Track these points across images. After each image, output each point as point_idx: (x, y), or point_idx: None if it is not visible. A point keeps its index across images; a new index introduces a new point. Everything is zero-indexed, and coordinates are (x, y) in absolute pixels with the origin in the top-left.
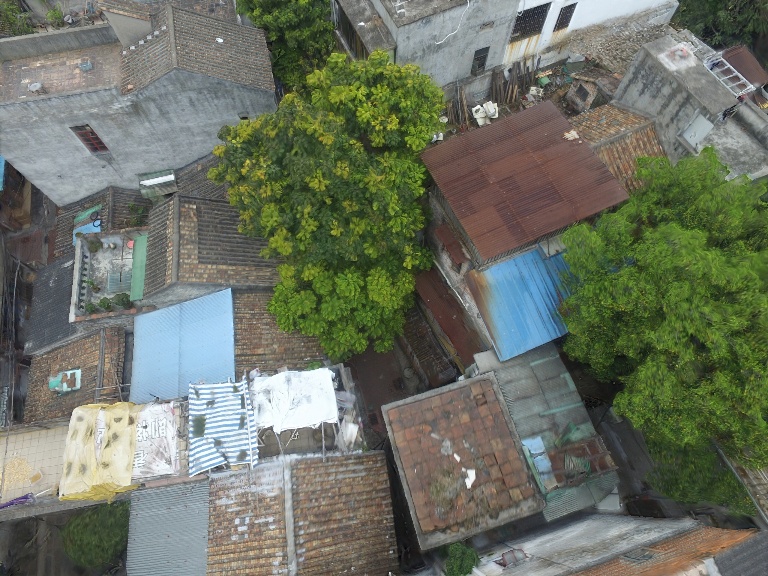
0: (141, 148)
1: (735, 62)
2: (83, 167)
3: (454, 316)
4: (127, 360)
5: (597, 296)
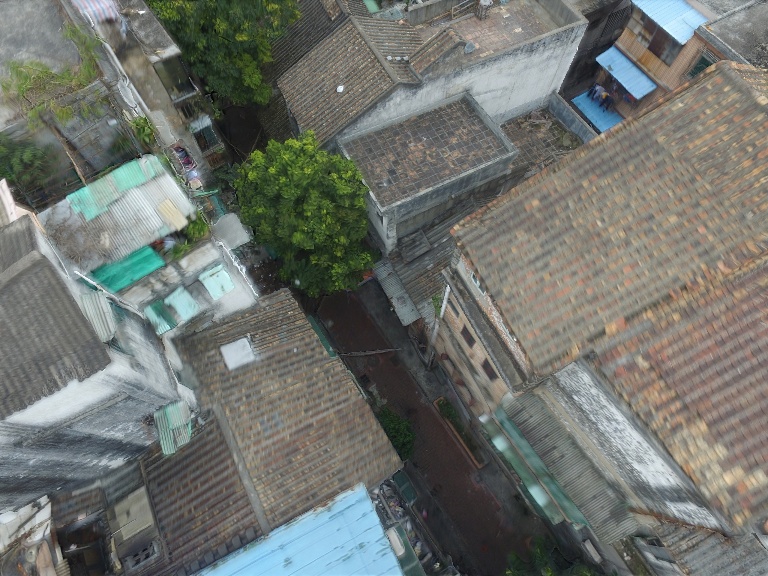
0: None
1: None
2: None
3: None
4: None
5: None
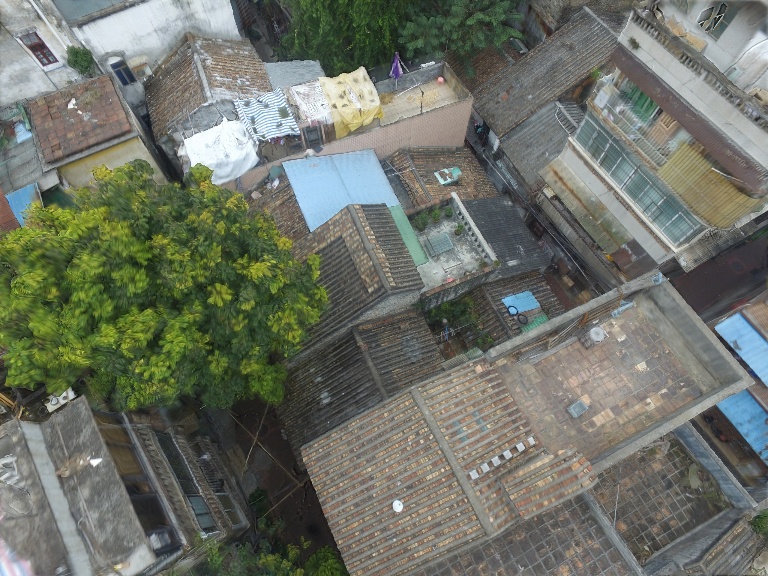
0: None
1: None
2: None
3: None
4: None
5: None
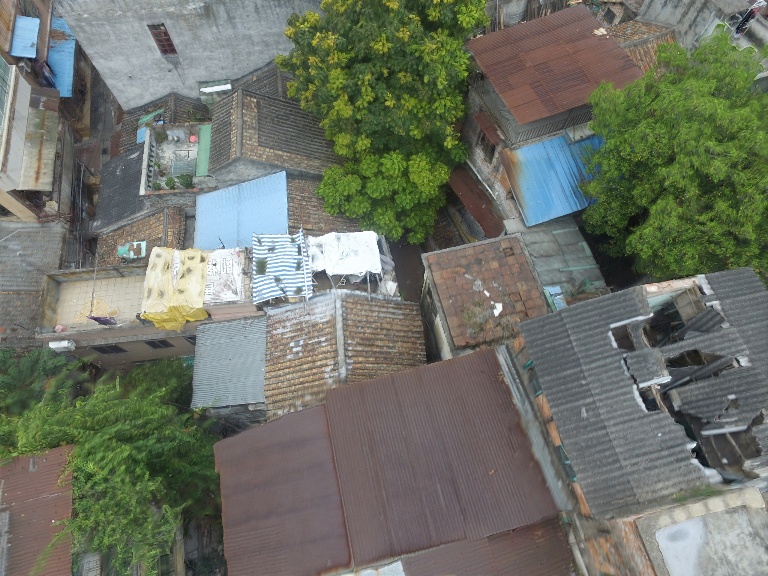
0: (205, 54)
1: None
2: (152, 69)
3: (483, 206)
4: (185, 239)
5: (617, 148)
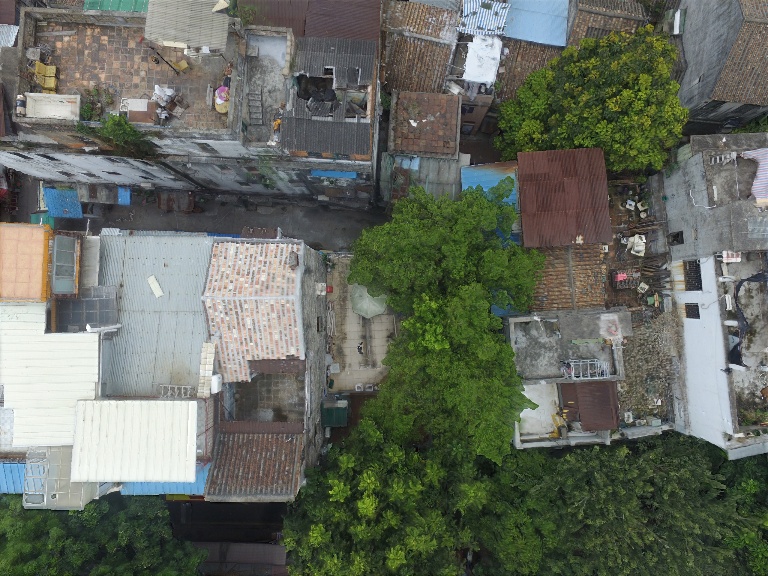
0: (703, 6)
1: (606, 412)
2: None
3: None
4: None
5: None
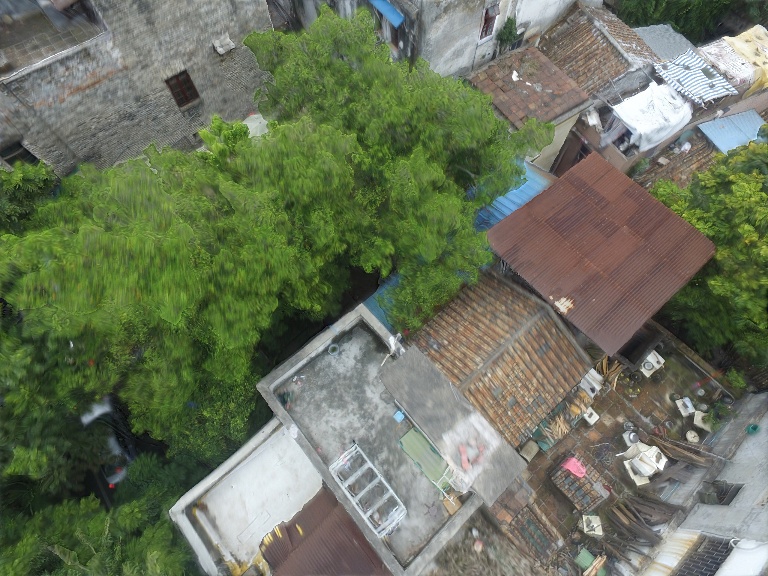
0: None
1: None
2: None
3: None
4: None
5: None
